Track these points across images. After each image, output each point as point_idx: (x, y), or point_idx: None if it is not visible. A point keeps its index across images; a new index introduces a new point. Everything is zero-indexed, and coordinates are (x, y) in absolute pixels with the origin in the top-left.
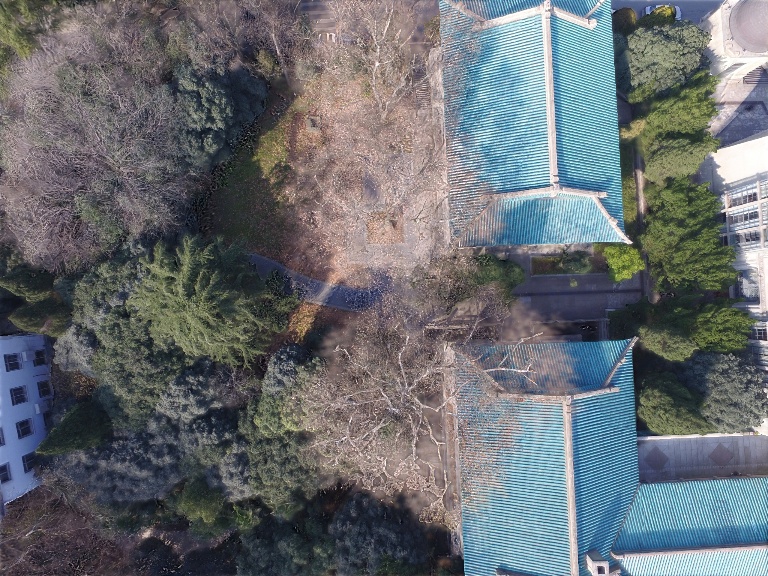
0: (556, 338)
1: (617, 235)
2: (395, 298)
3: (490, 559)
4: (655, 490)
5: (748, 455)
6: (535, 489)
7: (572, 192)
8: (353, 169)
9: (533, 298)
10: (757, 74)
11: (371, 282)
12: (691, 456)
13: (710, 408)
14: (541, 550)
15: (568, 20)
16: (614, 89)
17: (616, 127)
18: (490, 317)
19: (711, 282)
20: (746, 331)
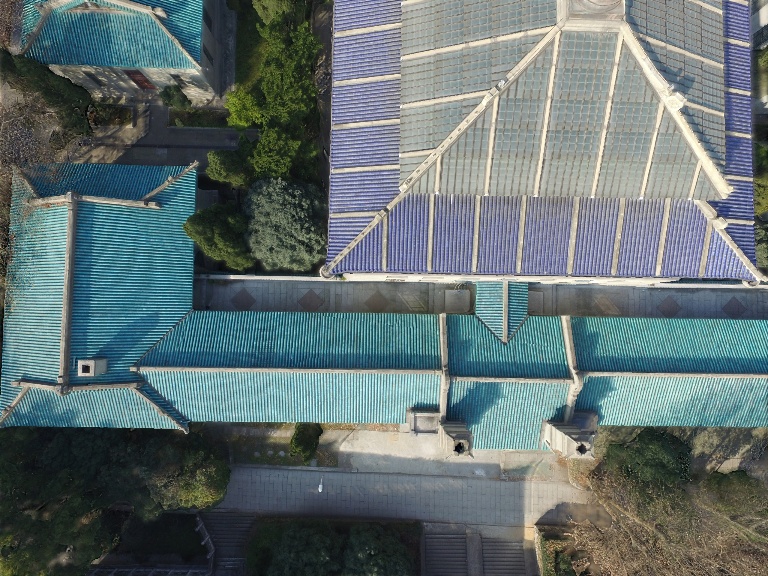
0: None
1: (189, 60)
2: (34, 143)
3: (17, 370)
4: (205, 317)
5: (339, 303)
6: (50, 294)
7: None
8: (3, 14)
9: (170, 150)
10: None
11: (11, 126)
12: (279, 300)
13: (258, 233)
14: (48, 355)
15: None
16: None
17: None
18: None
19: (283, 113)
20: (291, 154)
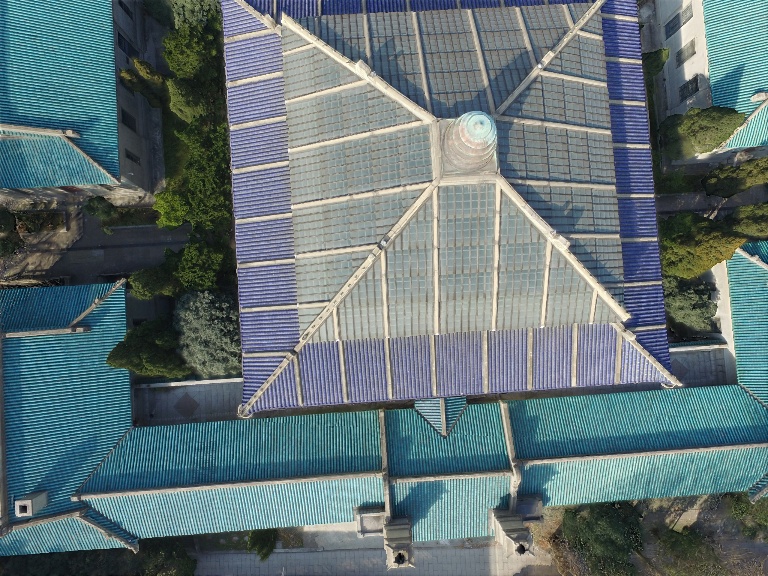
0: None
1: (107, 176)
2: None
3: None
4: (145, 433)
5: None
6: None
7: (16, 129)
8: None
9: (106, 251)
10: None
11: None
12: (223, 402)
13: (189, 348)
14: None
15: None
16: (110, 29)
17: (111, 68)
18: (61, 271)
19: (207, 221)
20: (215, 267)
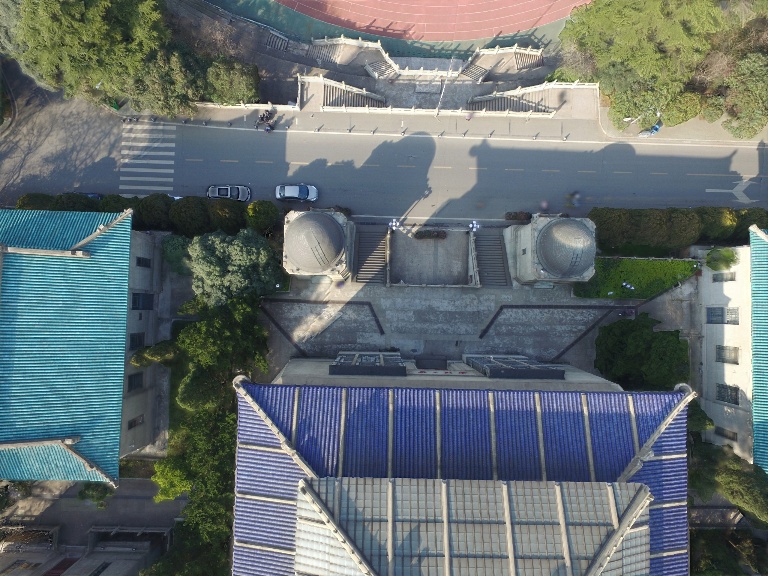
0: (121, 545)
1: None
2: None
3: None
4: None
5: None
6: None
7: (12, 447)
8: None
9: None
10: (375, 269)
11: None
12: None
13: None
14: None
15: (43, 254)
16: (123, 316)
17: (121, 357)
18: (51, 518)
19: (205, 533)
20: None
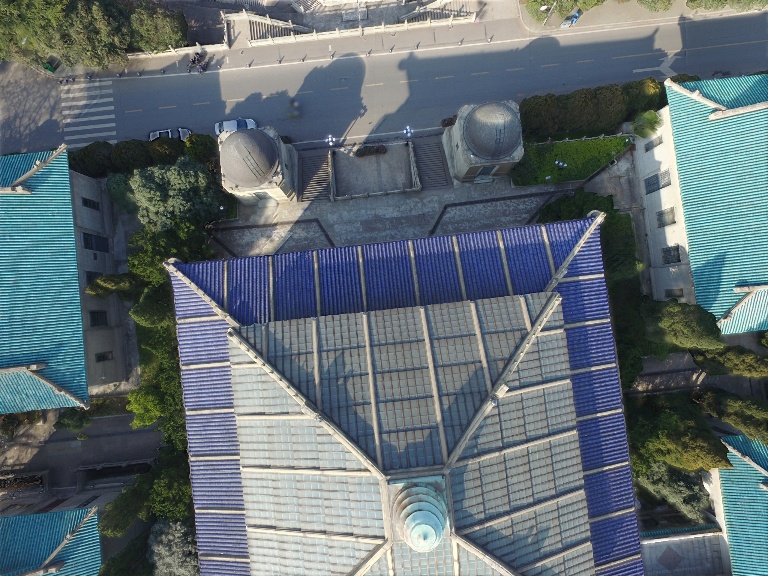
0: (110, 481)
1: None
2: None
3: None
4: None
5: None
6: None
7: None
8: None
9: (83, 441)
10: (319, 188)
11: None
12: None
13: None
14: None
15: None
16: (72, 247)
17: (75, 287)
18: (39, 464)
19: None
20: (186, 501)
